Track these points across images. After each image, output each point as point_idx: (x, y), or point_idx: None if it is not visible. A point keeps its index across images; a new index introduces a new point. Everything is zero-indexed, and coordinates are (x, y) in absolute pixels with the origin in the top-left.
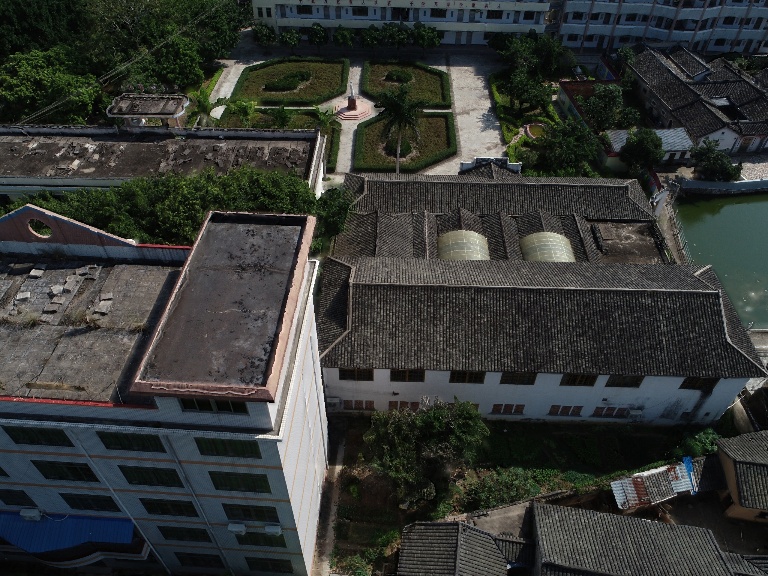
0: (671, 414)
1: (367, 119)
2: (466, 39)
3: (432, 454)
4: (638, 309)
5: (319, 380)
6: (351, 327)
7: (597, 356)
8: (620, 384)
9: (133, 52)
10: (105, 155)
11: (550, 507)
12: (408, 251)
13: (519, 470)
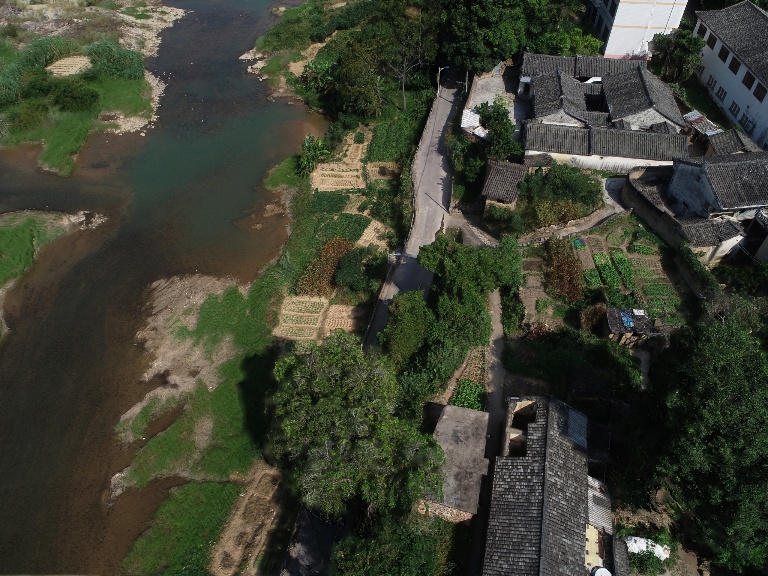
0: (761, 142)
1: None
2: None
3: (671, 36)
4: None
5: None
6: (722, 10)
7: None
8: (758, 96)
9: None
10: None
11: (669, 89)
12: None
13: None
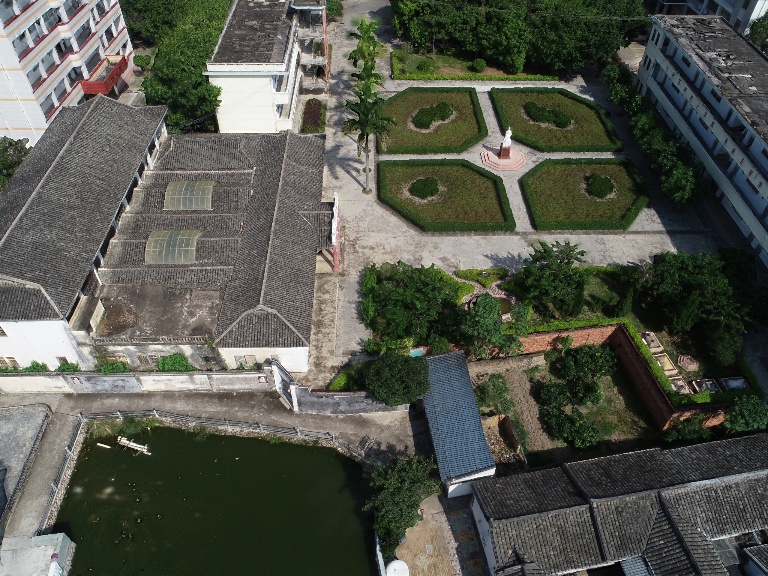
0: None
1: (487, 169)
2: (759, 243)
3: None
4: (4, 225)
5: (25, 92)
6: None
7: None
8: None
9: (474, 6)
10: (269, 6)
11: None
12: (201, 164)
13: None
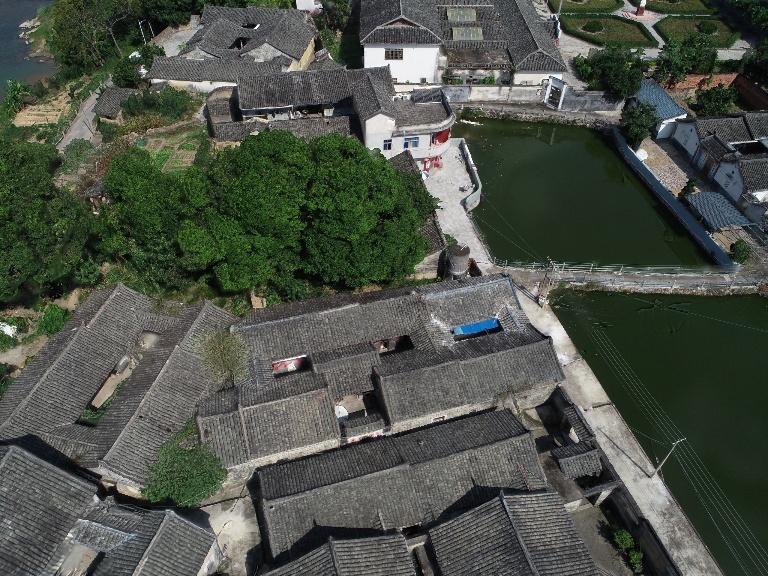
0: None
1: None
2: None
3: None
4: None
5: None
6: None
7: (368, 7)
8: None
9: None
10: None
11: (313, 31)
12: (457, 3)
13: (334, 36)
